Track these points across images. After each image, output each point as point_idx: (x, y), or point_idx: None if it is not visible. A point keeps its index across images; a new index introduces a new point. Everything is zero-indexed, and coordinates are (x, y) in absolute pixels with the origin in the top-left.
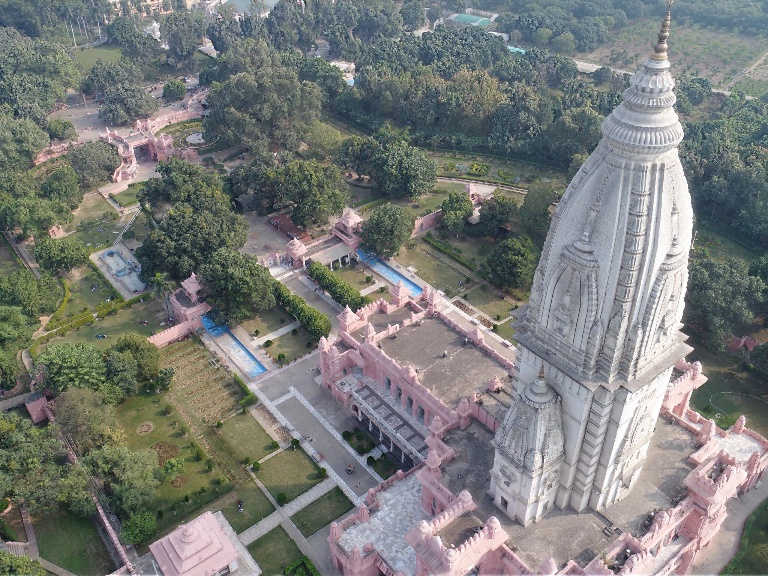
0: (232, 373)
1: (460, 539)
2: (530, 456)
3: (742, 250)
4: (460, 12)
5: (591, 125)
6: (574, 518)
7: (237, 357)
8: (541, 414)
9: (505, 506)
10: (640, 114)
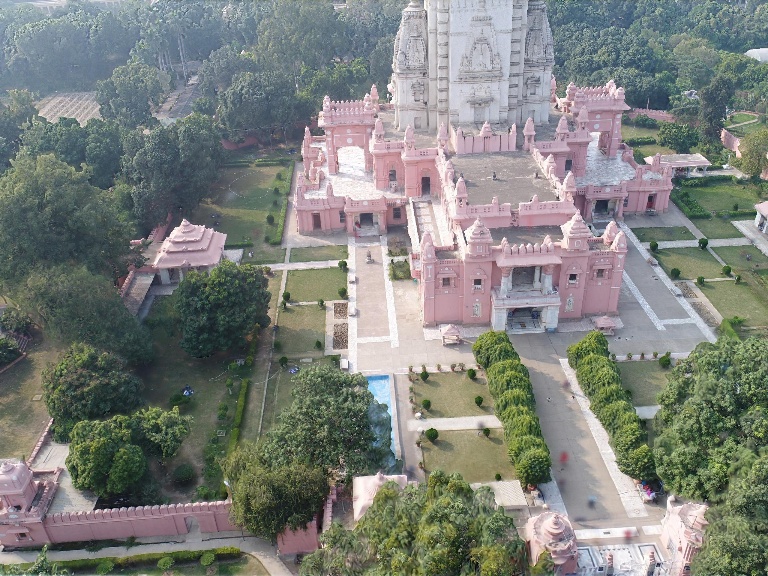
0: None
1: None
2: None
3: None
4: None
5: None
6: None
7: None
8: None
9: None
10: None
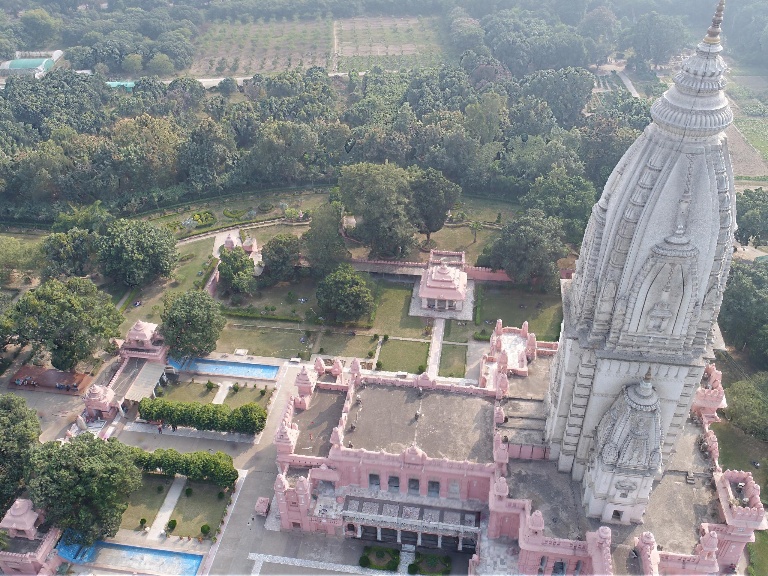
0: None
1: (634, 575)
2: (656, 457)
3: (481, 202)
4: (11, 58)
5: (301, 136)
6: (661, 488)
7: (147, 567)
8: (658, 413)
9: (616, 518)
10: (711, 98)
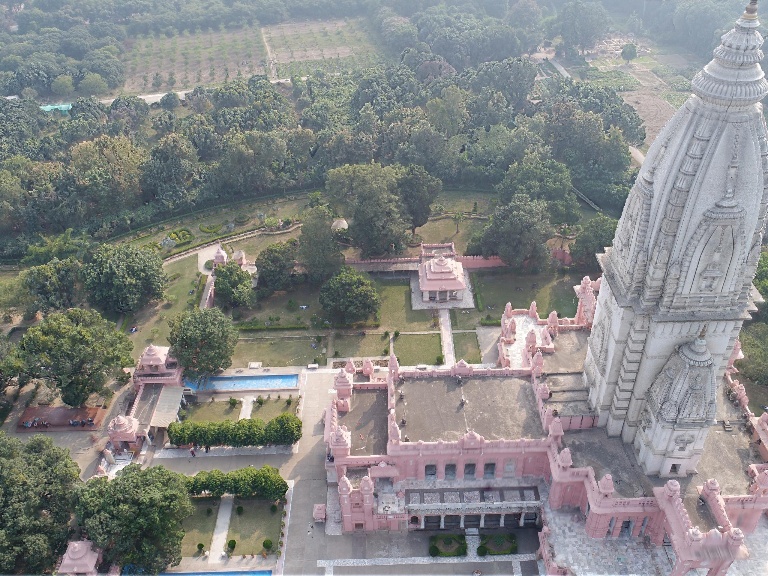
0: None
1: (707, 520)
2: (712, 408)
3: (453, 193)
4: None
5: (271, 144)
6: None
7: None
8: None
9: (673, 471)
10: (752, 70)
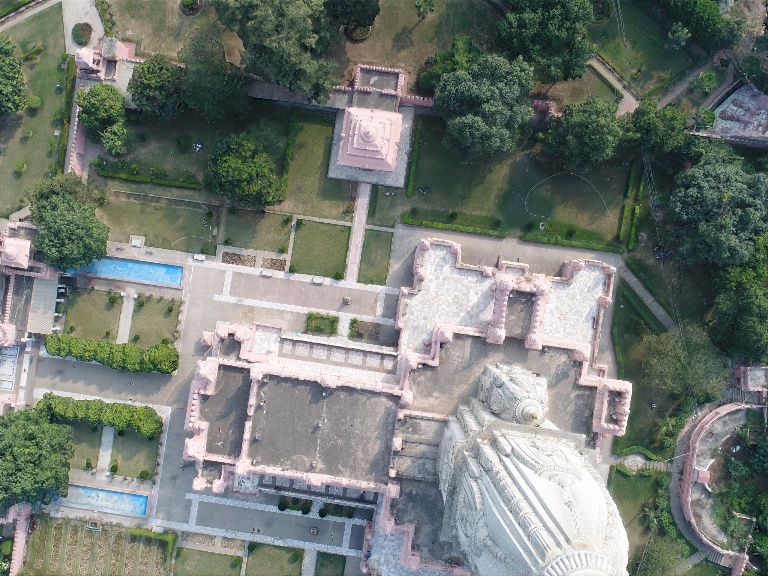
0: (122, 525)
1: None
2: None
3: None
4: None
5: None
6: None
7: (104, 504)
8: None
9: None
10: None
